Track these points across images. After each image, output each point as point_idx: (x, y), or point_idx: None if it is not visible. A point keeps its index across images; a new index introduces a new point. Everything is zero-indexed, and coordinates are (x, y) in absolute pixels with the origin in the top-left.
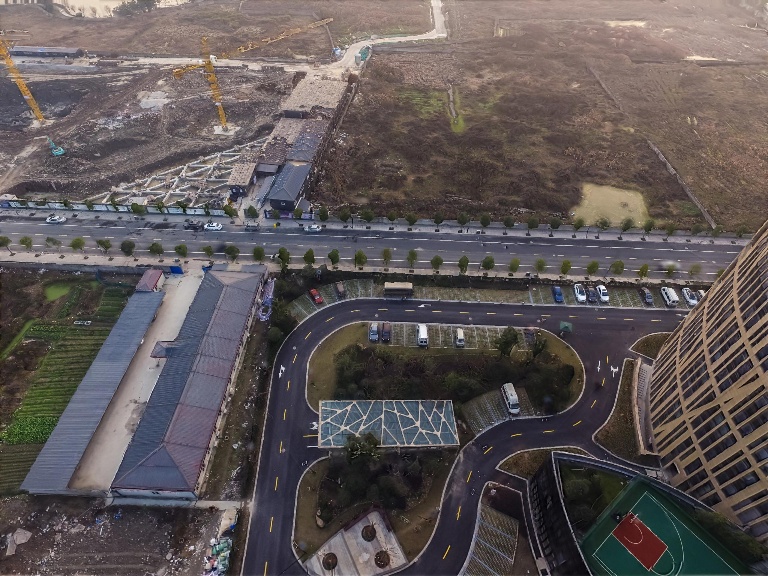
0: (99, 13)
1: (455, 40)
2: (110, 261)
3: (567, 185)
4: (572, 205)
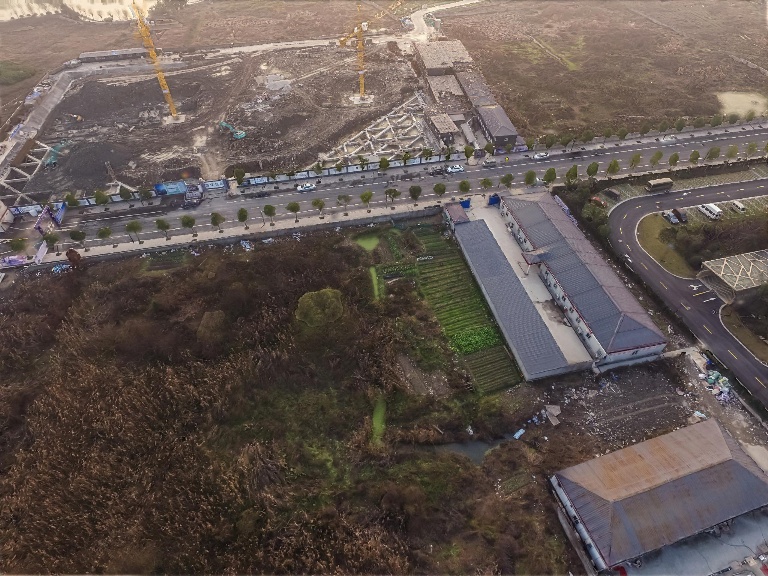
0: (131, 15)
1: (500, 1)
2: (394, 210)
3: (705, 94)
4: (719, 108)
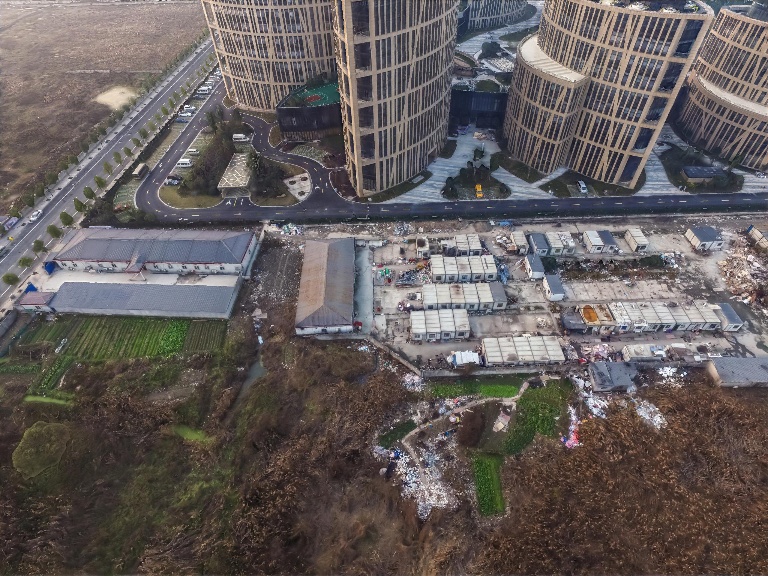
0: None
1: None
2: None
3: (87, 104)
4: None
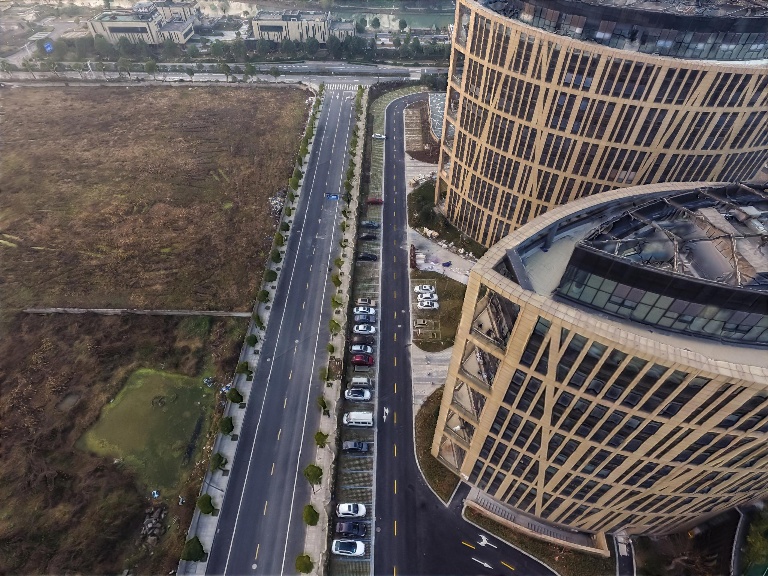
0: None
1: None
2: None
3: (80, 484)
4: (132, 488)
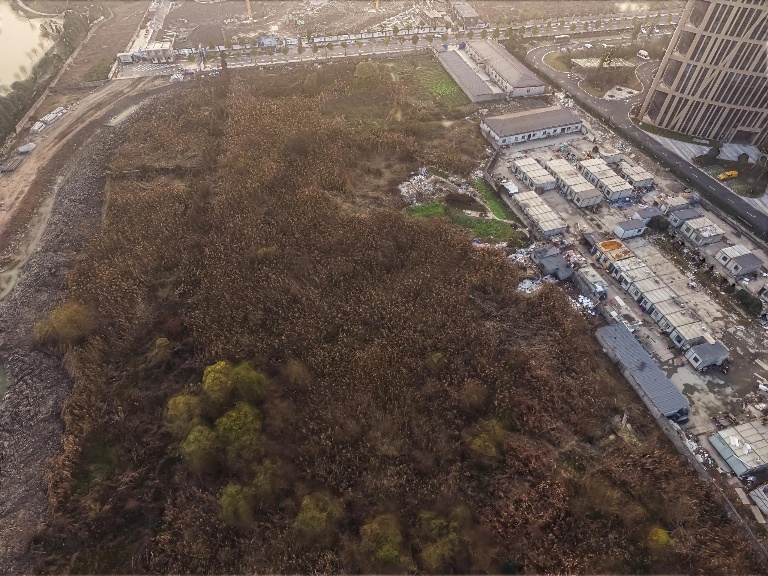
0: None
1: None
2: None
3: (607, 2)
4: None
